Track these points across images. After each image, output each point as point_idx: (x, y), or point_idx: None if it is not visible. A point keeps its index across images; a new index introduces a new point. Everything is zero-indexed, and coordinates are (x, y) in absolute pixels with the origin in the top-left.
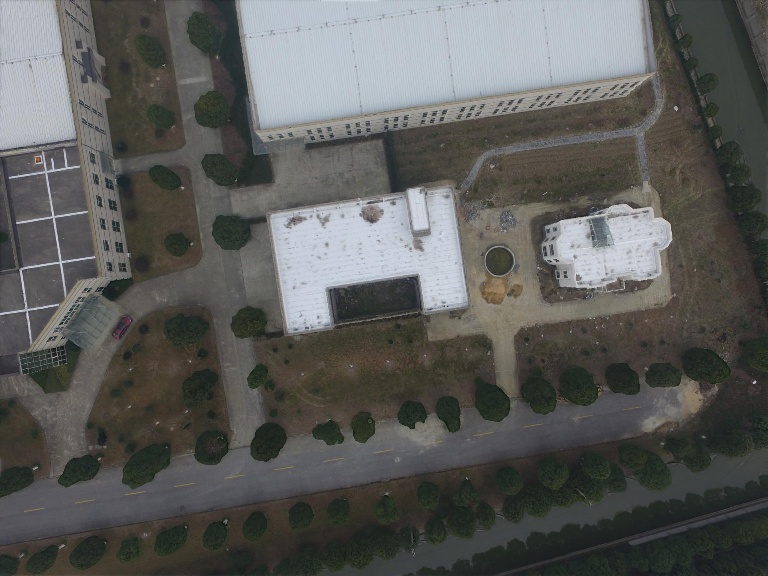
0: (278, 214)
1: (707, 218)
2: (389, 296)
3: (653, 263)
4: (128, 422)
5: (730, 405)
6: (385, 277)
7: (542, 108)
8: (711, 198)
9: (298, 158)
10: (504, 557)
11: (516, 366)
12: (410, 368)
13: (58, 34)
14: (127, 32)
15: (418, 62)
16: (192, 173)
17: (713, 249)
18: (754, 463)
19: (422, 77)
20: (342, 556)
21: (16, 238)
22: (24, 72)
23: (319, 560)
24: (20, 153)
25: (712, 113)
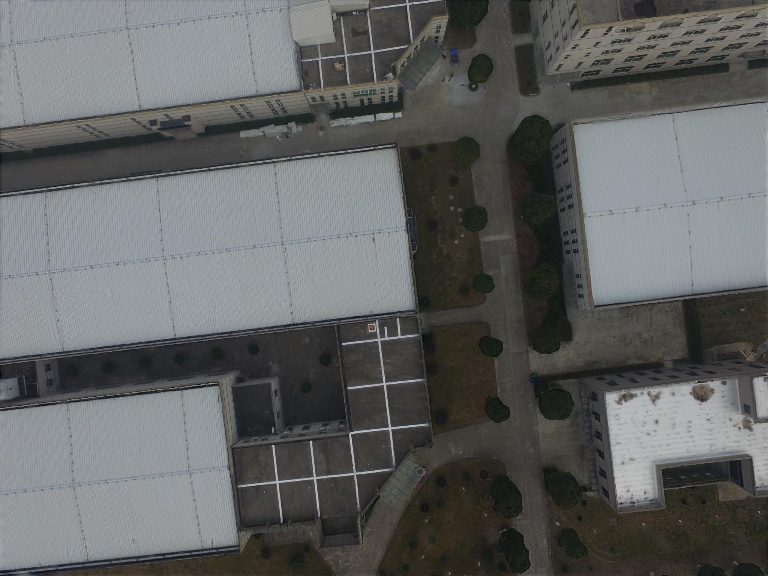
0: None
1: None
2: None
3: None
4: (420, 571)
5: None
6: (714, 456)
7: None
8: None
9: (597, 317)
10: None
11: None
12: (701, 528)
13: (401, 209)
14: (434, 189)
15: (752, 244)
16: (492, 328)
17: None
18: None
19: (755, 258)
20: None
21: (347, 403)
22: (367, 245)
23: None
24: (357, 322)
25: None
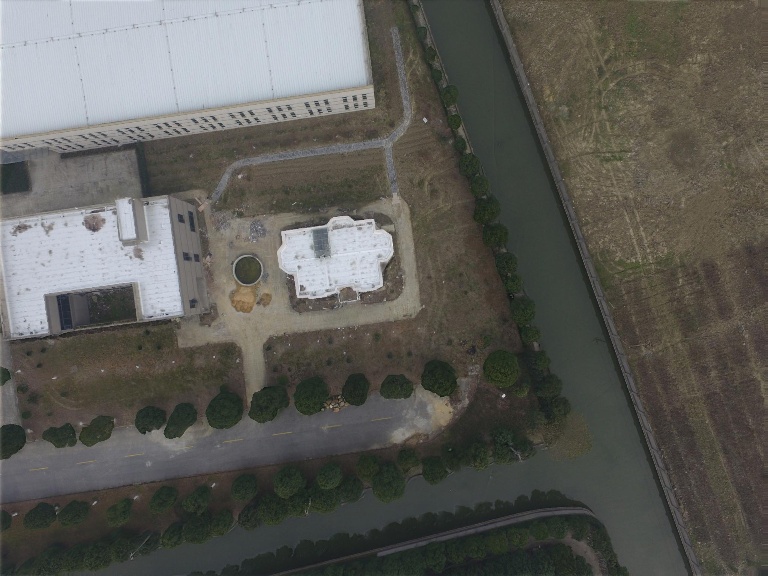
0: (5, 222)
1: (456, 230)
2: None
3: (377, 275)
4: None
5: (479, 418)
6: (105, 285)
7: (291, 119)
8: (461, 210)
9: (54, 167)
10: (268, 564)
11: (265, 374)
12: (160, 374)
13: None
14: None
15: (141, 75)
16: None
17: (462, 261)
18: (507, 477)
19: (146, 90)
20: (80, 557)
21: None
22: None
23: (59, 560)
24: None
25: (453, 125)
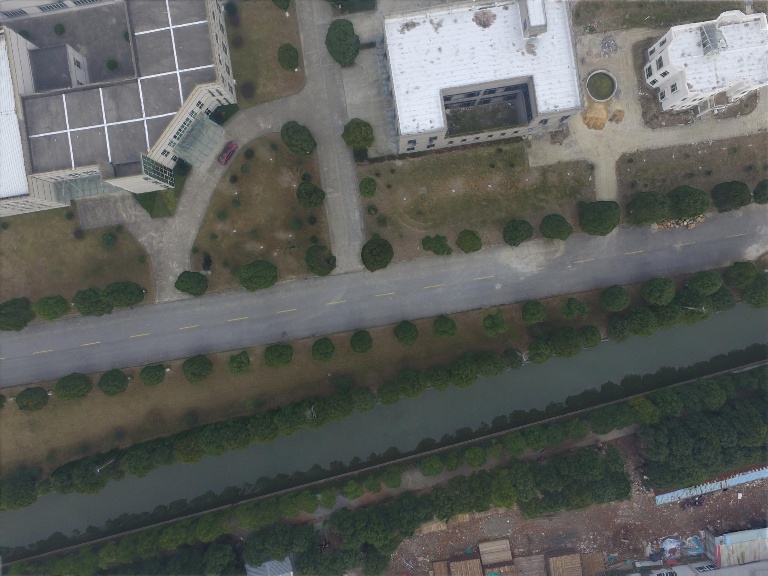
0: (391, 20)
1: None
2: (491, 121)
3: (765, 71)
4: (233, 247)
5: None
6: None
7: None
8: None
9: None
10: (600, 396)
11: (617, 192)
12: (511, 193)
13: None
14: None
15: None
16: (296, 1)
17: None
18: None
19: None
20: (448, 373)
21: (135, 48)
22: None
23: (424, 378)
24: None
25: None
